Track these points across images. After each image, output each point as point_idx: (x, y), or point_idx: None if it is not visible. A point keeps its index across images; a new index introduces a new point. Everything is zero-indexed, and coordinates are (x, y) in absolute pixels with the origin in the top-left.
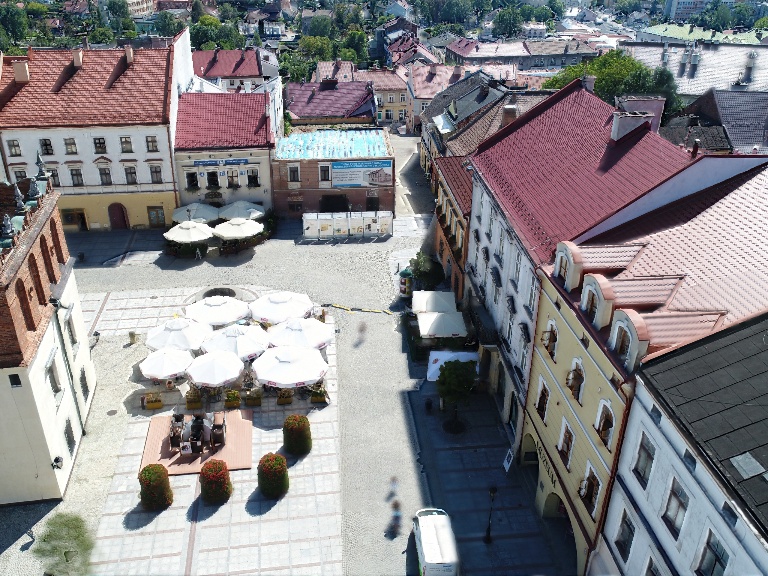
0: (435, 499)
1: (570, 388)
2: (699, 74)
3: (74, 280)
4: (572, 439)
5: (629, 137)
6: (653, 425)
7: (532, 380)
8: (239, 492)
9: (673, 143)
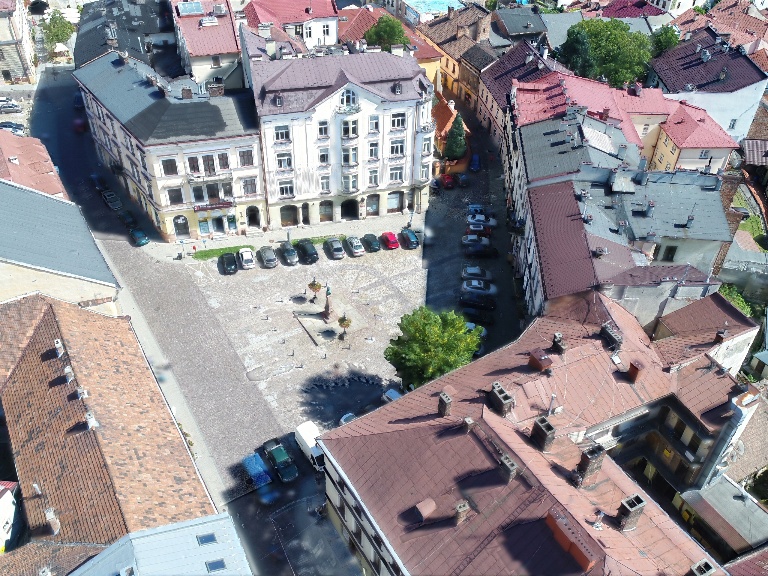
0: None
1: None
2: (692, 69)
3: None
4: None
5: None
6: None
7: None
8: None
9: None
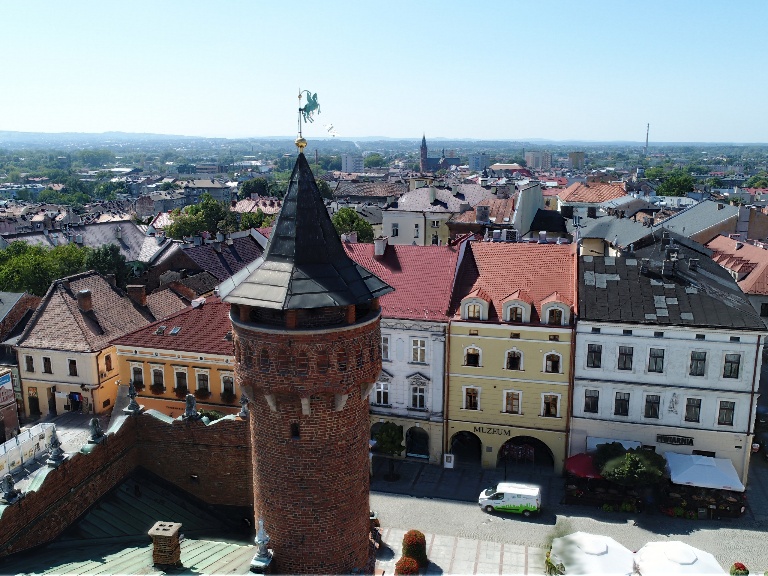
0: (461, 499)
1: (510, 368)
2: None
3: None
4: (516, 397)
5: (386, 251)
6: (597, 336)
7: (451, 396)
8: None
9: (197, 289)
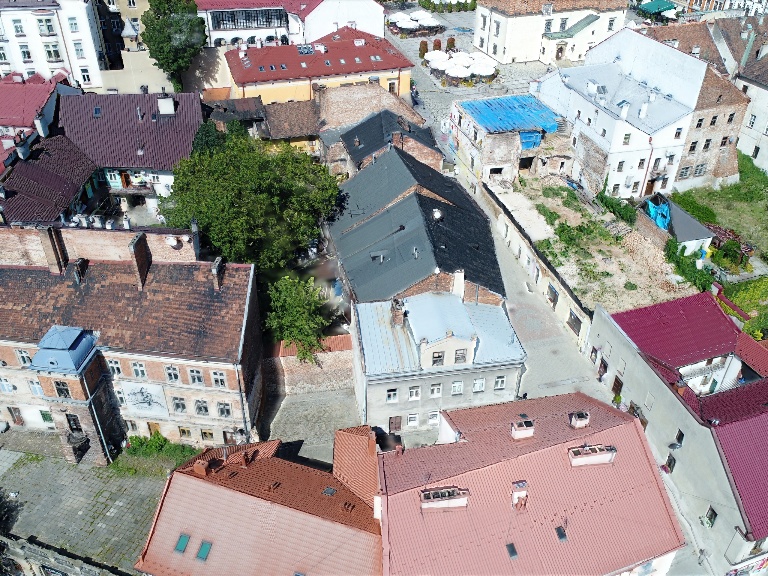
0: None
1: None
2: None
3: (508, 23)
4: None
5: None
6: None
7: None
8: (432, 50)
9: None
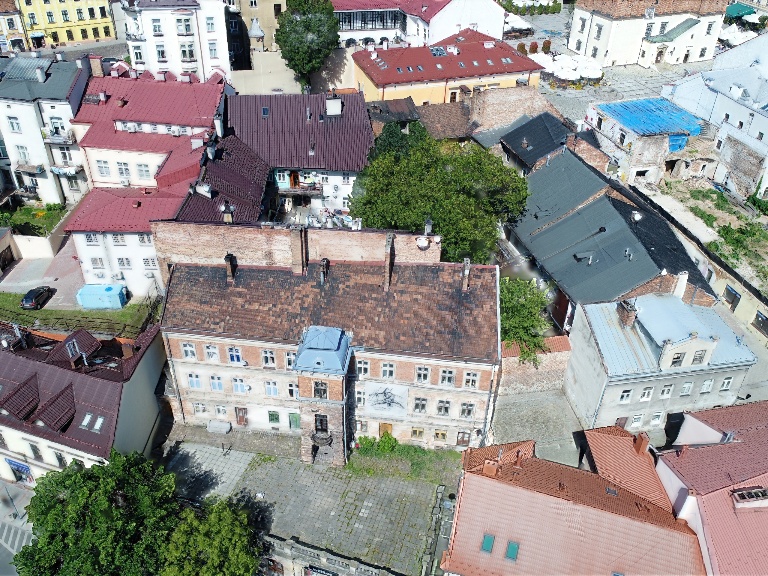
0: None
1: None
2: None
3: (612, 26)
4: None
5: None
6: None
7: None
8: None
9: None
